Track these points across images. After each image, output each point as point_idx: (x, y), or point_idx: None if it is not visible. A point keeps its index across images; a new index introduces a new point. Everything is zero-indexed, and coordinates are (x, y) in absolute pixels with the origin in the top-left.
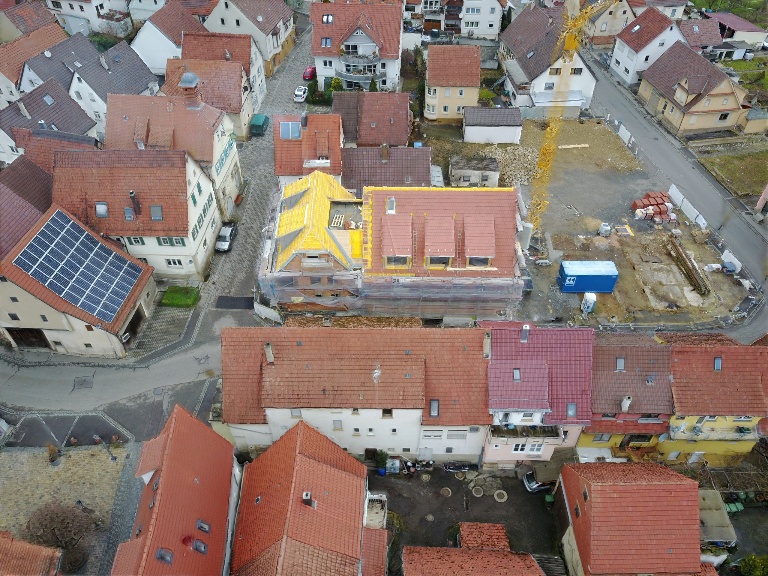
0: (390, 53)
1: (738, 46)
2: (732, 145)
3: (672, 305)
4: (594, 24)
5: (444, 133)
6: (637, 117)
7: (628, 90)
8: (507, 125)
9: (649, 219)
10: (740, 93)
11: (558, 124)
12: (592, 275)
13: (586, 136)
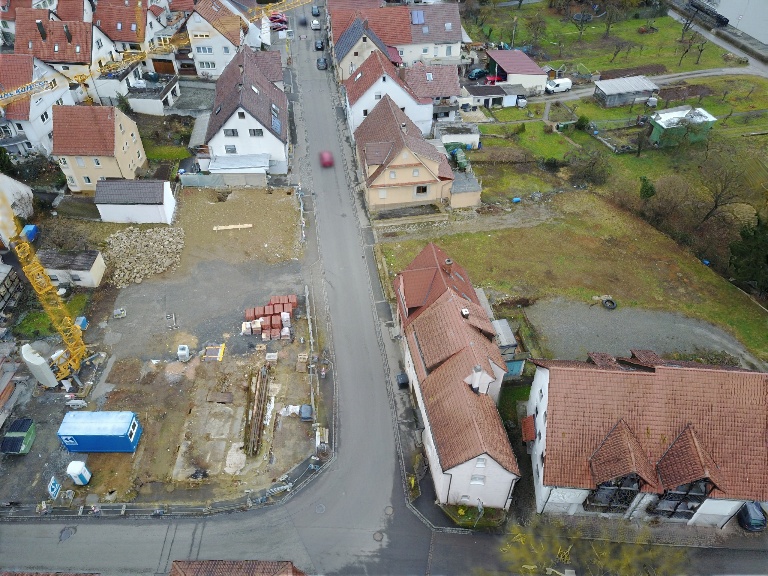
0: (18, 113)
1: (509, 91)
2: (428, 224)
3: (199, 473)
4: (340, 66)
5: (84, 209)
6: (339, 185)
7: (352, 148)
8: (144, 203)
9: (258, 334)
10: (431, 164)
11: (236, 195)
12: (90, 435)
13: (259, 212)
